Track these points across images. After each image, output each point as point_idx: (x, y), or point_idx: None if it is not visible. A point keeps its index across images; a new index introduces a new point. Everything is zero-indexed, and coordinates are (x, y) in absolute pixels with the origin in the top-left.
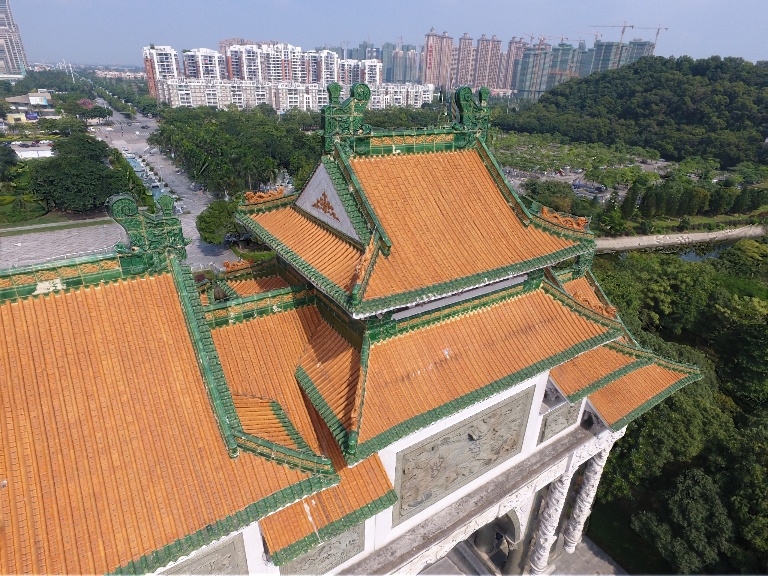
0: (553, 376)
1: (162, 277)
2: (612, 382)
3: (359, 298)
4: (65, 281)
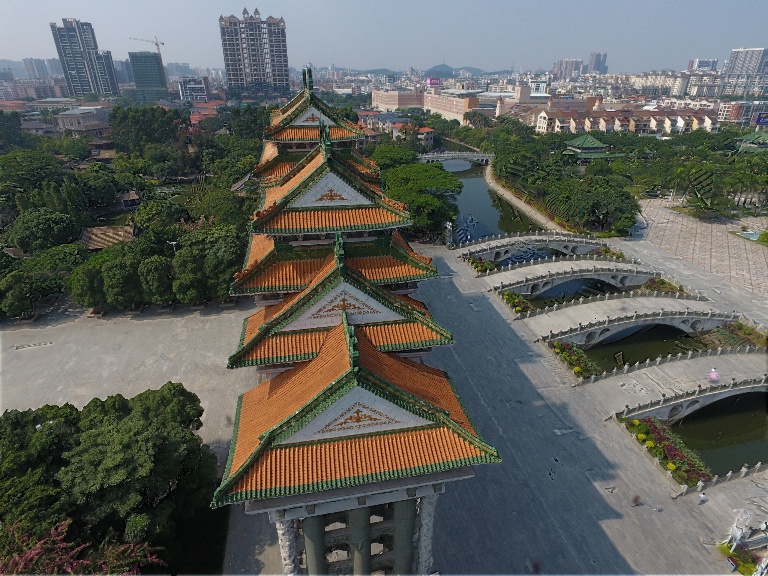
0: (261, 310)
1: None
2: (264, 404)
3: (262, 186)
4: None
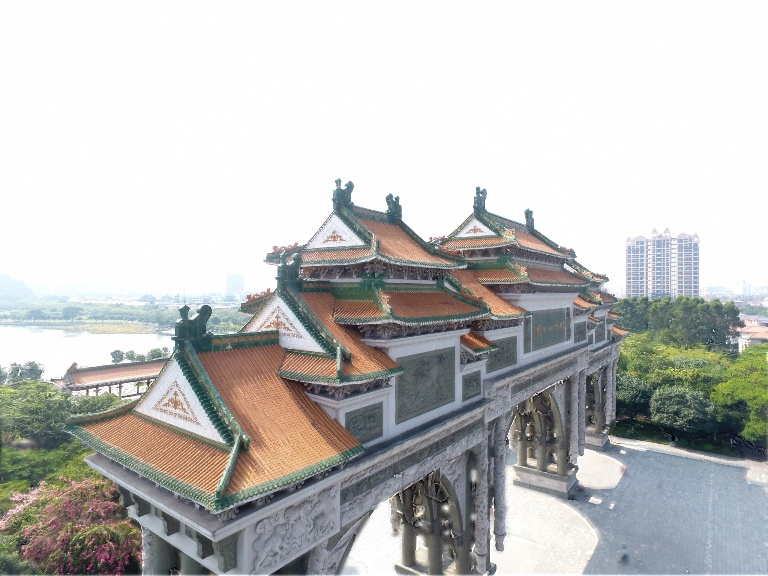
0: None
1: None
2: None
3: None
4: None
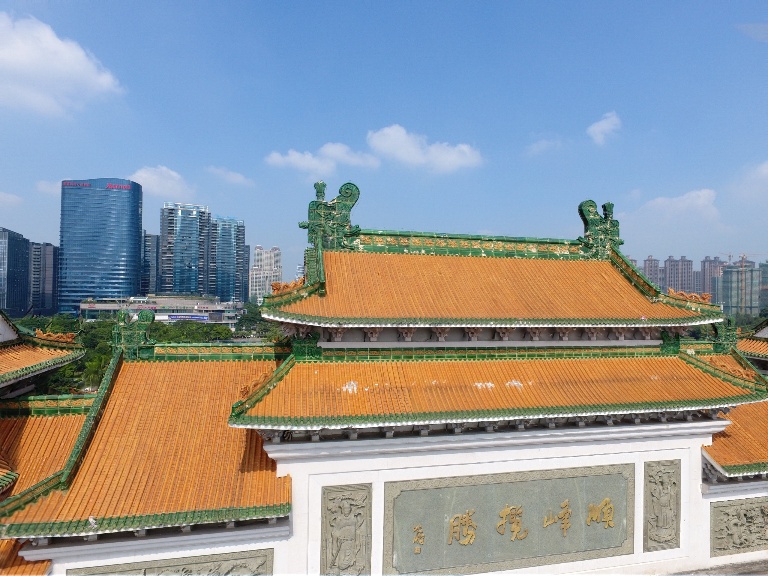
0: None
1: (727, 356)
2: None
3: None
4: (695, 350)
